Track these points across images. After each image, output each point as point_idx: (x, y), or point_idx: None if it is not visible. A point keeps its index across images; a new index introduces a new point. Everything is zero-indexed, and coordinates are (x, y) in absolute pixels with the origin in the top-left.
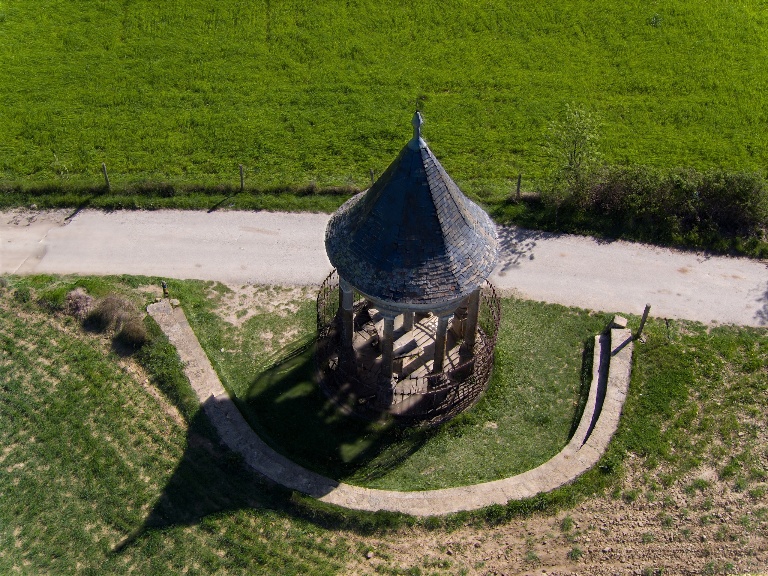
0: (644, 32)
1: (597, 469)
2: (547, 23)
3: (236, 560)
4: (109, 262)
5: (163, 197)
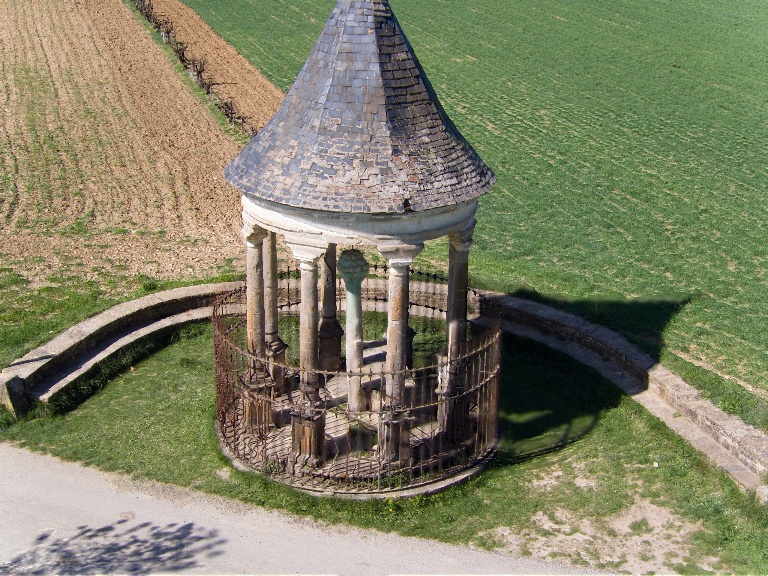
0: None
1: None
2: None
3: None
4: None
5: None
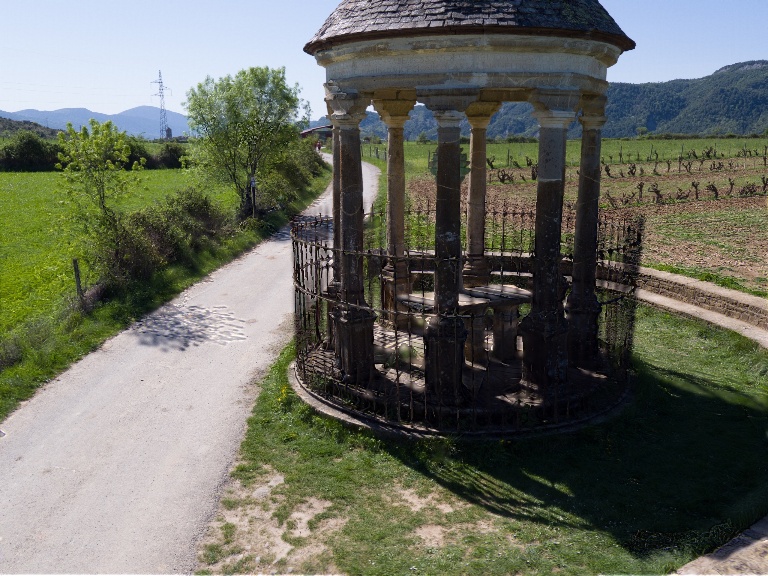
0: None
1: None
2: None
3: None
4: None
5: None
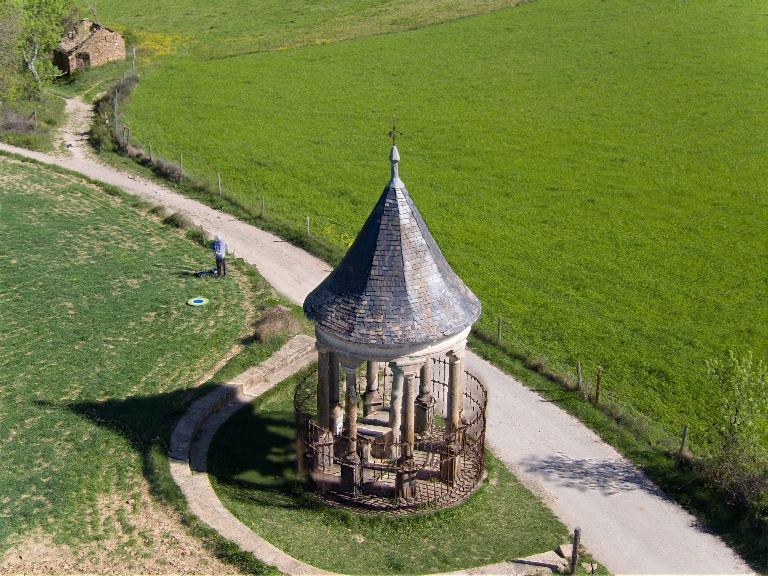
0: None
1: None
2: None
3: None
4: None
5: None
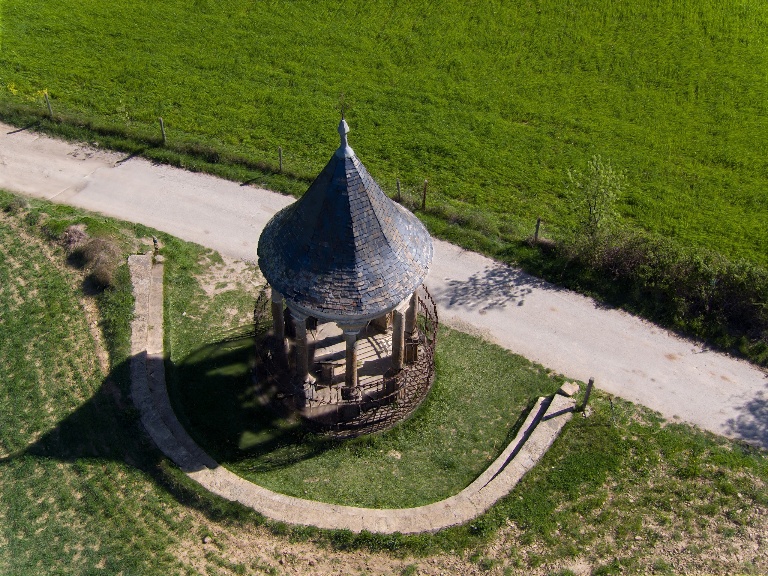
0: (761, 106)
1: (467, 527)
2: (662, 76)
3: (86, 506)
4: (132, 209)
5: (207, 162)
